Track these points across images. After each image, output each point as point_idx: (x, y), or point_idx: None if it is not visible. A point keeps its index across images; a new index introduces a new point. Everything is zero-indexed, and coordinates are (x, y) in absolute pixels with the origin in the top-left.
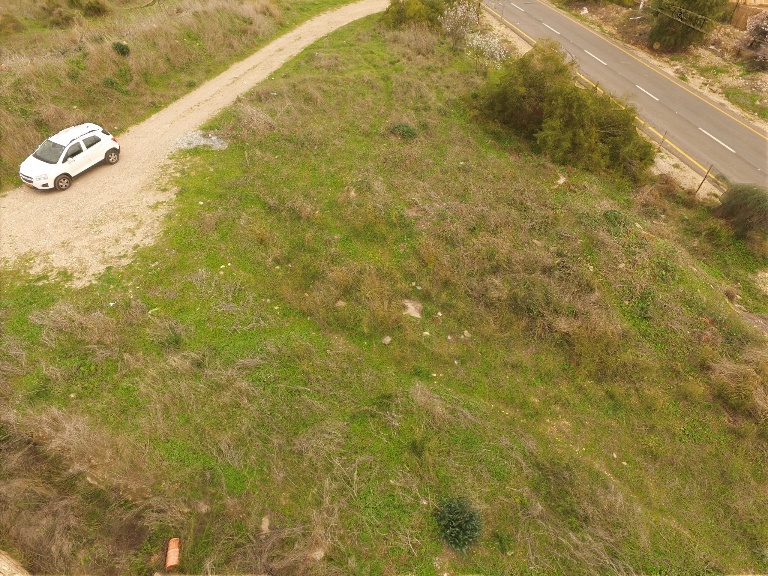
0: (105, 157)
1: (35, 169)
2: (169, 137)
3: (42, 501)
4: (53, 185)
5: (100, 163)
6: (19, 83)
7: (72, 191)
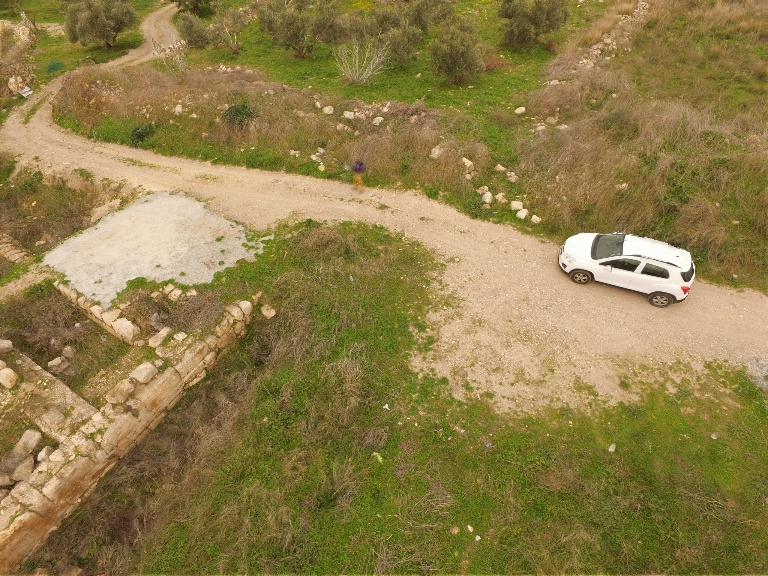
0: (652, 293)
1: (576, 247)
2: (767, 344)
3: (185, 436)
4: (570, 271)
5: (640, 293)
6: (724, 163)
7: (577, 289)
